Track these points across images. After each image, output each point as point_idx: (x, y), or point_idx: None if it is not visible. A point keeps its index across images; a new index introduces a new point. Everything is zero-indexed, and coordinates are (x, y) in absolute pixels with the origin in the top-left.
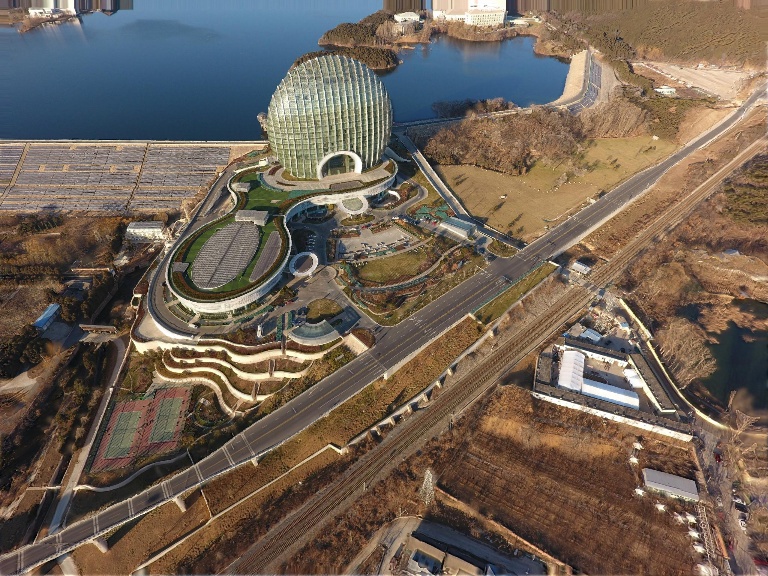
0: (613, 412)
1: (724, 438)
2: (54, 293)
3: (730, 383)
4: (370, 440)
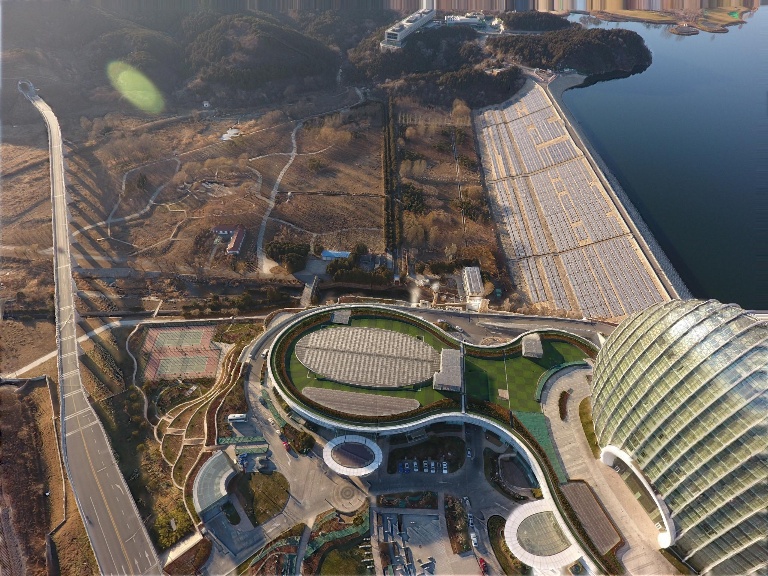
0: None
1: None
2: (362, 249)
3: None
4: (41, 573)
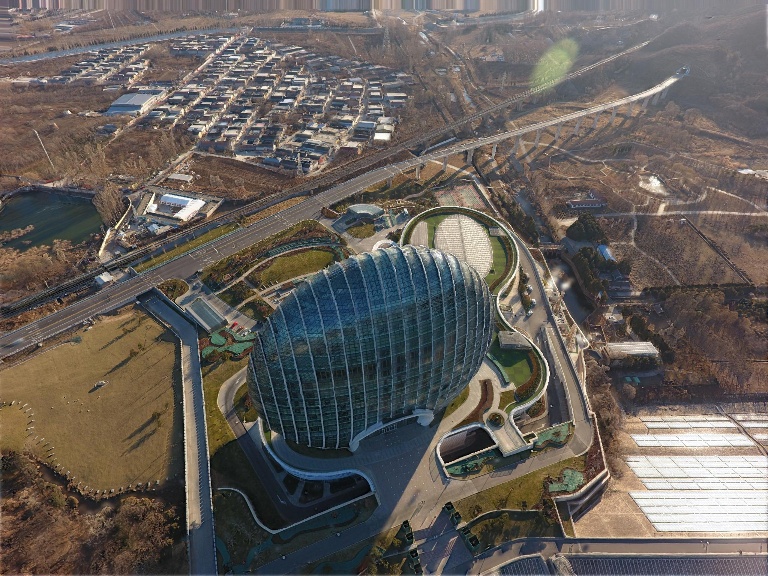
0: (185, 191)
1: (129, 194)
2: (625, 267)
3: (84, 219)
4: None
